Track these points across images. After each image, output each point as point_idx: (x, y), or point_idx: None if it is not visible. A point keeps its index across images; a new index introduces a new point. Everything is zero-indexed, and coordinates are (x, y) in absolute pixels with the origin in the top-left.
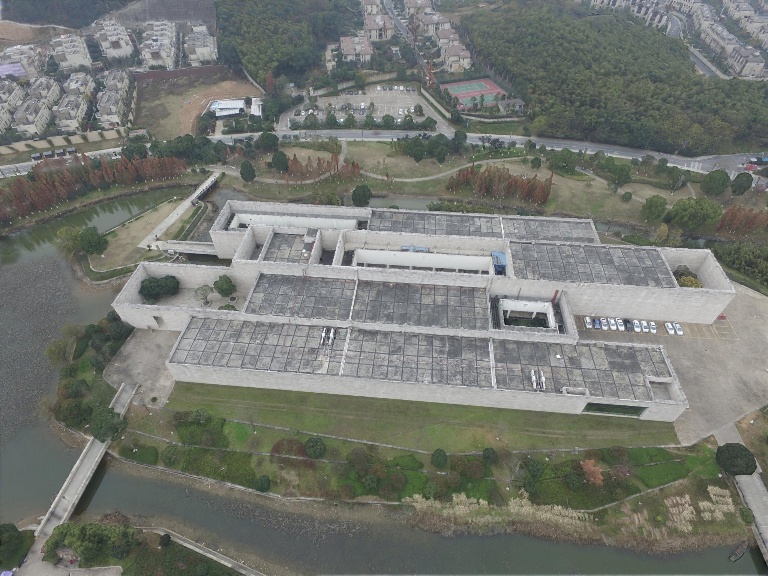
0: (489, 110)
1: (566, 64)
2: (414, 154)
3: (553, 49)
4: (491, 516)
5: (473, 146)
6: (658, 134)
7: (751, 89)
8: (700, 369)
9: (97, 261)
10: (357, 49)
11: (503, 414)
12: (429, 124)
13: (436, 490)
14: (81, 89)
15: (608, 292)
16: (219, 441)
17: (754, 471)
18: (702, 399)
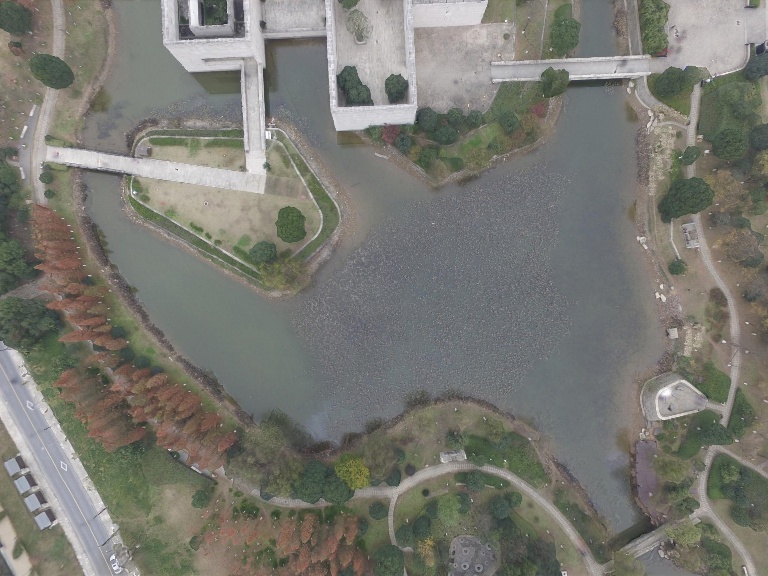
0: None
1: None
2: None
3: None
4: None
5: None
6: None
7: None
8: None
9: None
10: None
11: None
12: None
13: None
14: None
15: None
16: None
17: None
18: None
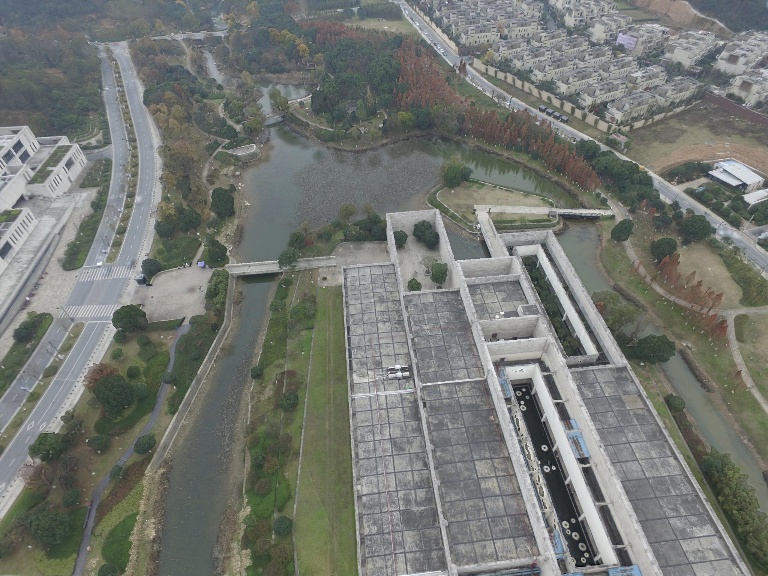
0: None
1: None
2: None
3: None
4: None
5: None
6: None
7: None
8: None
9: (447, 191)
10: None
11: None
12: None
13: (248, 526)
14: (639, 80)
15: None
16: (293, 331)
17: None
18: None
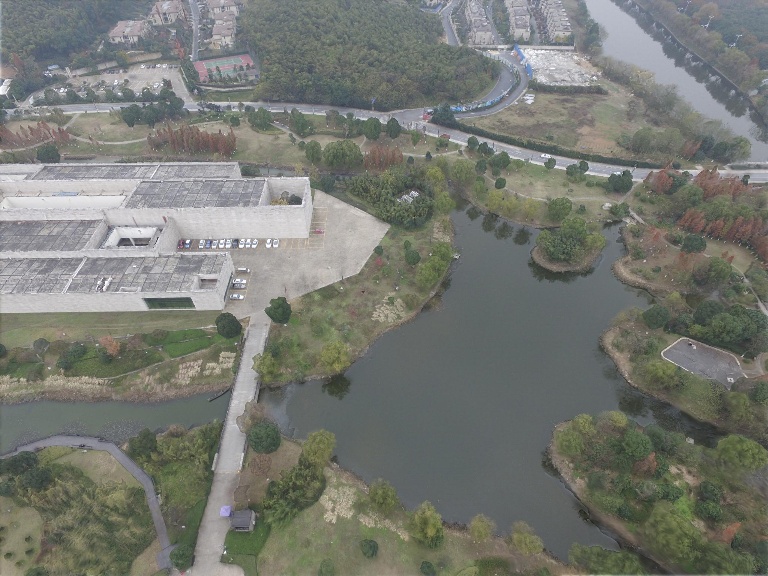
0: (223, 80)
1: (299, 37)
2: (123, 119)
3: (294, 24)
4: (26, 390)
5: (186, 111)
6: (356, 93)
7: (448, 52)
8: (274, 271)
9: None
10: (125, 31)
11: (82, 316)
12: (164, 95)
13: None
14: None
15: (205, 215)
16: None
17: (230, 331)
18: (259, 292)
